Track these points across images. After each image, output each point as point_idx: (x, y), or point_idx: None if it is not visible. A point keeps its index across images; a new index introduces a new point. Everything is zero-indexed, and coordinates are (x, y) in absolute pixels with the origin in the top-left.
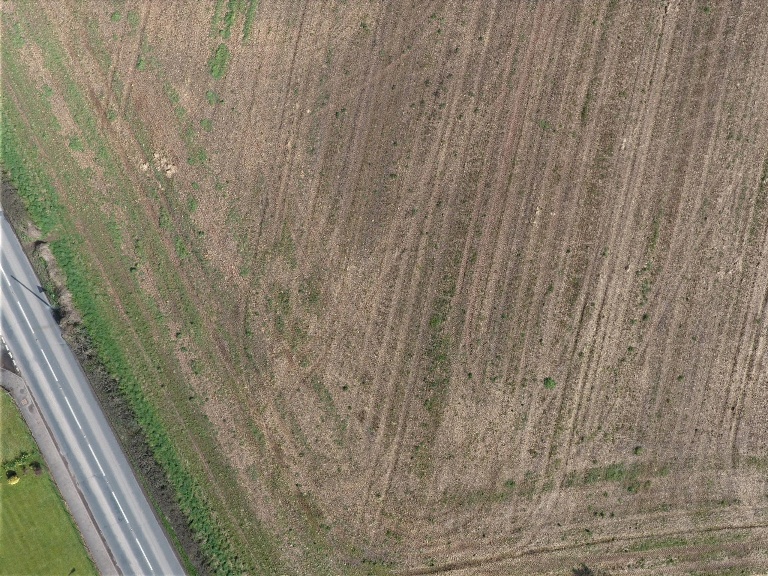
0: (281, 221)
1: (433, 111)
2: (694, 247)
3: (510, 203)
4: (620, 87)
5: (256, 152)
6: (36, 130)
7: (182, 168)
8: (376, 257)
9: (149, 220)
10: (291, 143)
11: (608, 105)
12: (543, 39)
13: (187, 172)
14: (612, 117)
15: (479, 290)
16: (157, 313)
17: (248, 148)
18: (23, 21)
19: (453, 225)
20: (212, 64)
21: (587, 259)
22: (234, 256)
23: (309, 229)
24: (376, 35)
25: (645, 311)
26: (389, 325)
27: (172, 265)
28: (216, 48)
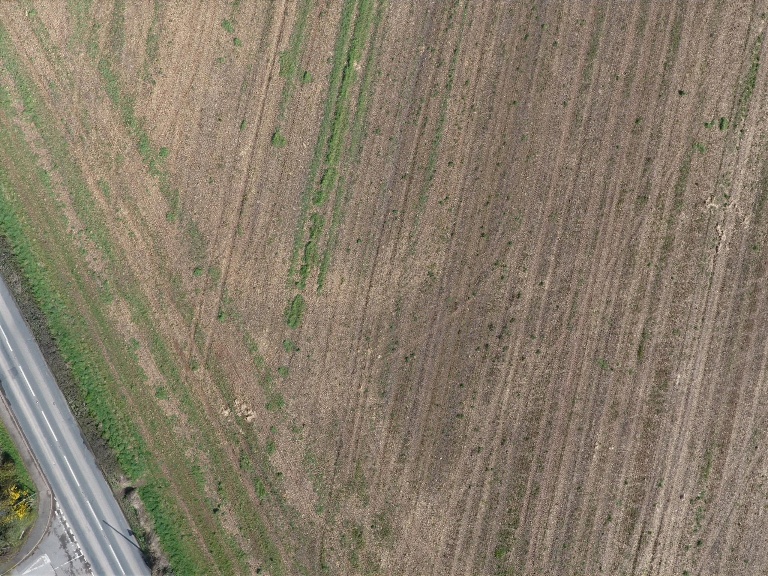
0: (354, 461)
1: (497, 354)
2: (745, 475)
3: (570, 439)
4: (674, 325)
5: (330, 396)
6: (125, 381)
7: (261, 413)
8: (444, 493)
9: (231, 463)
10: (363, 387)
11: (663, 343)
12: (600, 282)
13: (266, 417)
14: (666, 354)
15: (542, 522)
16: (239, 551)
17: (323, 393)
18: (112, 278)
19: (517, 461)
20: (289, 315)
21: (644, 490)
22: (310, 495)
23: (381, 468)
24: (443, 283)
25: (699, 537)
26: (457, 556)
27: (252, 505)
28: (292, 299)
